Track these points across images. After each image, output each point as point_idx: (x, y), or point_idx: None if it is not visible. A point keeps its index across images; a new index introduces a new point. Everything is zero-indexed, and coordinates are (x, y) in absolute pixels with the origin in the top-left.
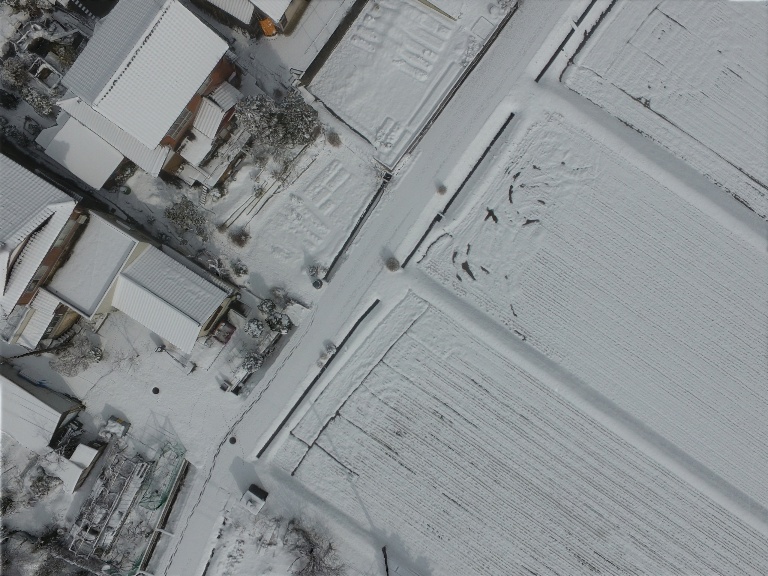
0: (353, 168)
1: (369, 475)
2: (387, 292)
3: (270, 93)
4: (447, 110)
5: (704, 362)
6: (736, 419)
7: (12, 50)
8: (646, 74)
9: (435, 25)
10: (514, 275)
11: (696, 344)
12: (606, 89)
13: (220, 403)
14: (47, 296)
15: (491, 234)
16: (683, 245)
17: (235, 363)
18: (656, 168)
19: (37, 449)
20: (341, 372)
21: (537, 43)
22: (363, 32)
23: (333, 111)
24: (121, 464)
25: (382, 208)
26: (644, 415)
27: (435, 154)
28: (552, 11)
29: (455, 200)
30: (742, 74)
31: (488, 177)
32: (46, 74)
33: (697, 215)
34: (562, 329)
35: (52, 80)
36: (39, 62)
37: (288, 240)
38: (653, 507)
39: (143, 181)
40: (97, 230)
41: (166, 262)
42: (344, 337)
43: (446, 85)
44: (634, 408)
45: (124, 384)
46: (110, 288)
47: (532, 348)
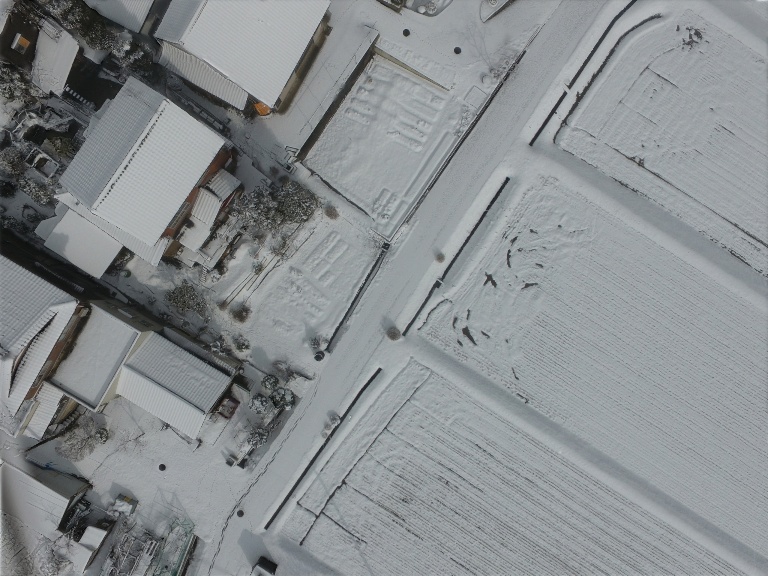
0: (351, 239)
1: (377, 542)
2: (389, 361)
3: (266, 171)
4: (443, 178)
5: (706, 419)
6: (739, 475)
7: (8, 138)
8: (639, 133)
9: (428, 96)
10: (514, 339)
11: (697, 402)
12: (600, 149)
13: (226, 477)
14: (51, 388)
15: (490, 299)
16: (681, 304)
17: (240, 437)
18: (652, 229)
19: (46, 533)
20: (346, 441)
21: (530, 108)
22: (357, 105)
23: (329, 184)
24: (130, 543)
25: (381, 278)
26: (648, 473)
27: (432, 222)
28: (544, 76)
29: (453, 266)
30: (734, 130)
31: (486, 243)
32: (43, 162)
33: (694, 274)
34: (564, 391)
35: (49, 168)
36: (35, 152)
37: (289, 313)
38: (660, 565)
39: (143, 263)
40: (99, 322)
41: (169, 349)
42: (348, 407)
43: (441, 155)
44: (638, 467)
45: (130, 462)
46: (114, 380)
47: (535, 411)
